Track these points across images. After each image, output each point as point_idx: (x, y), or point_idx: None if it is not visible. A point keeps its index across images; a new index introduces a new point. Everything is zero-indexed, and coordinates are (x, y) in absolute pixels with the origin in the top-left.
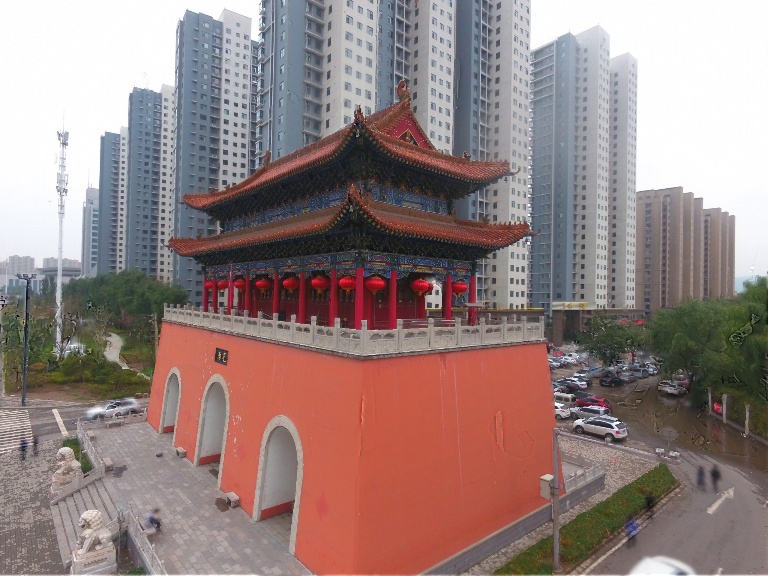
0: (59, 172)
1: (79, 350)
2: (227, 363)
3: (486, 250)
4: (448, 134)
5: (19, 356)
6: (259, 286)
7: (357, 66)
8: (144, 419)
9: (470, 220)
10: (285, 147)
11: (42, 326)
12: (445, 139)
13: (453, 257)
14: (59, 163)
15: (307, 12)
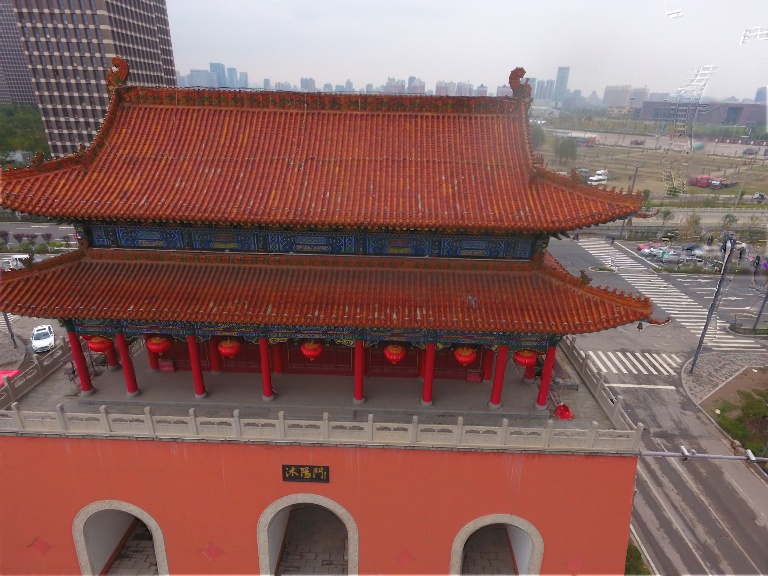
0: None
1: None
2: None
3: None
4: None
5: None
6: None
7: None
8: None
9: None
10: None
11: None
12: None
13: None
14: None
15: None
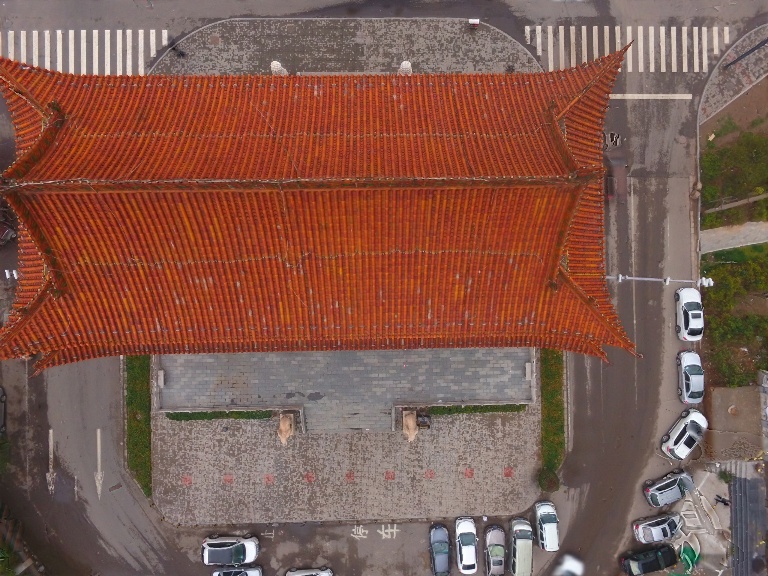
0: None
1: None
2: None
3: None
4: None
5: None
6: None
7: None
8: None
9: None
10: None
11: None
12: None
13: None
14: None
15: None
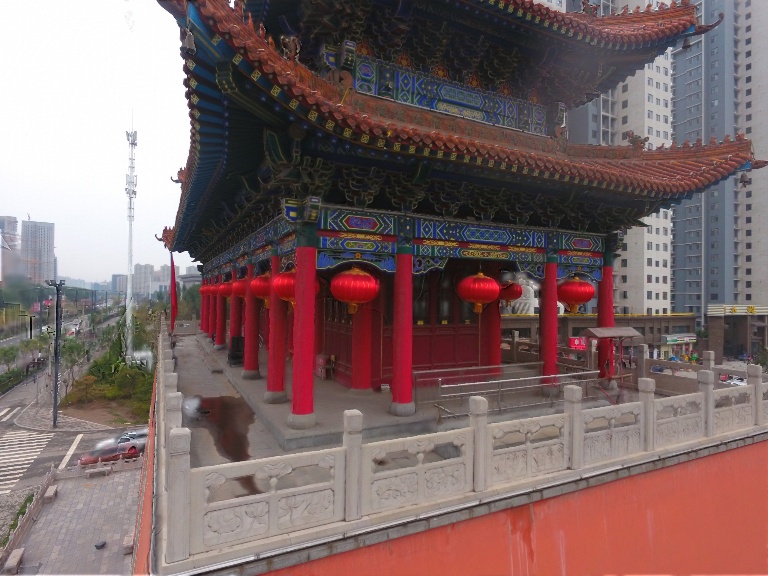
0: (128, 173)
1: (136, 361)
2: (152, 425)
3: (639, 207)
4: None
5: (51, 372)
6: (222, 292)
7: None
8: (139, 466)
9: (599, 145)
10: None
11: (104, 335)
12: None
13: (560, 224)
14: (128, 164)
15: None
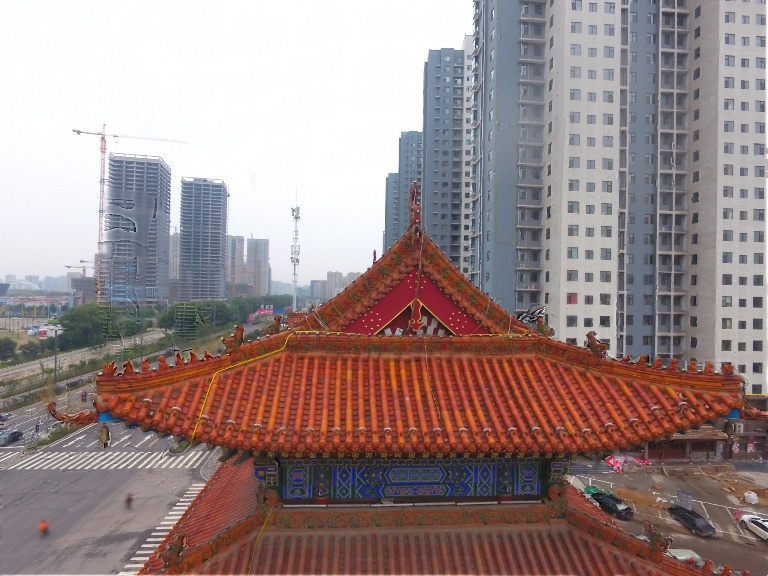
0: (293, 244)
1: None
2: None
3: None
4: (761, 118)
5: None
6: None
7: (589, 63)
8: None
9: (606, 524)
10: (494, 188)
11: None
12: (755, 128)
13: None
14: (293, 236)
15: (522, 15)
